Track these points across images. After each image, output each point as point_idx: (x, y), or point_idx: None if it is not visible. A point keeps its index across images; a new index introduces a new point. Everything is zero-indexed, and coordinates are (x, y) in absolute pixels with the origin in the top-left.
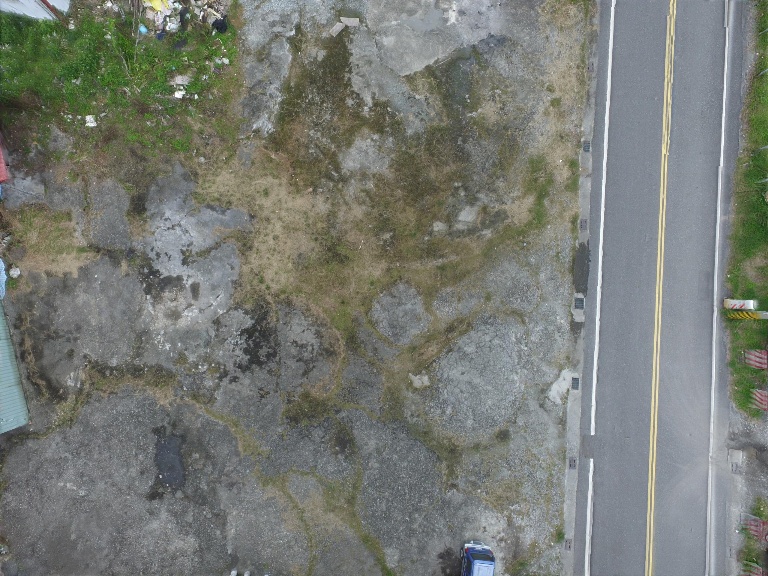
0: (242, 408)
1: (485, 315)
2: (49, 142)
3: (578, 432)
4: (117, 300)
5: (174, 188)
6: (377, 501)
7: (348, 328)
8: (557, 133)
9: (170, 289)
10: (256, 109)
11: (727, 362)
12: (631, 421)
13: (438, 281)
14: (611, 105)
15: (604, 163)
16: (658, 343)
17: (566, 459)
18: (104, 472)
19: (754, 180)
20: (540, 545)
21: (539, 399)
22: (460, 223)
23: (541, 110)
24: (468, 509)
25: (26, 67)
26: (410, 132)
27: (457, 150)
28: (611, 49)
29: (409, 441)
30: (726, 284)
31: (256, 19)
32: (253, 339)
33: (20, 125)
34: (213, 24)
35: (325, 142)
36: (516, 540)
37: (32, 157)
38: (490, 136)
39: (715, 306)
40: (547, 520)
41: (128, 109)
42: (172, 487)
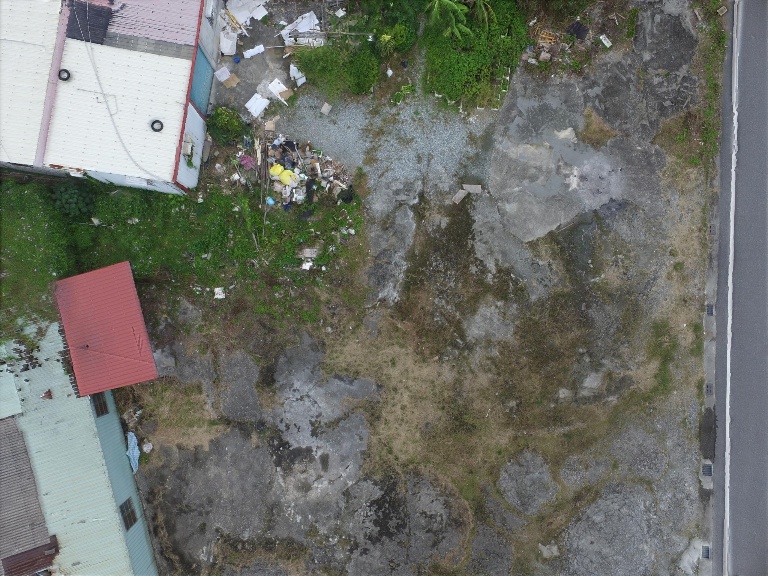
0: None
1: (613, 483)
2: (179, 315)
3: None
4: (248, 473)
5: (302, 359)
6: None
7: (477, 498)
8: (681, 297)
9: (300, 461)
10: (381, 278)
11: None
12: None
13: (565, 449)
14: (734, 268)
15: (728, 327)
16: None
17: None
18: None
19: None
20: None
21: (669, 568)
22: (586, 390)
23: (664, 275)
24: None
25: (157, 243)
26: (534, 298)
27: (581, 316)
28: (733, 212)
29: None
30: None
31: (380, 188)
32: (383, 510)
33: (150, 299)
34: (339, 195)
35: (450, 310)
36: None
37: (162, 330)
38: (614, 301)
39: None
40: None
41: (257, 282)
42: None
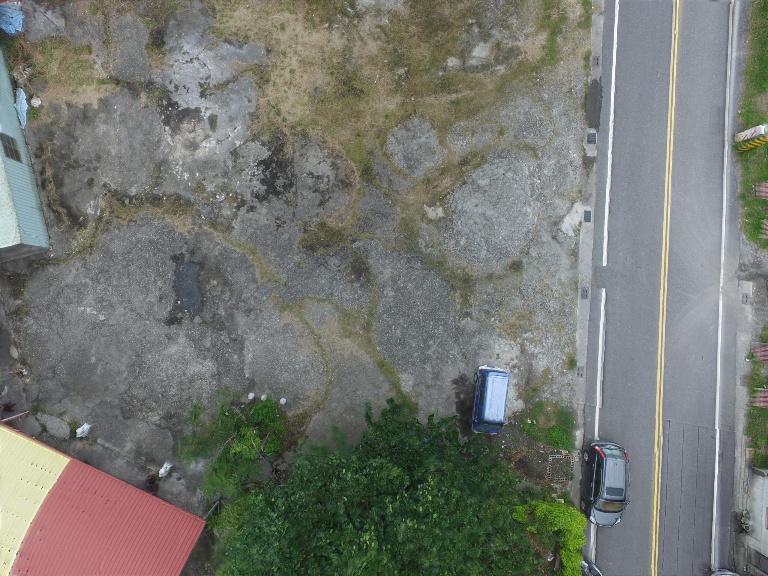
0: (259, 237)
1: (499, 149)
2: None
3: (590, 263)
4: (136, 131)
5: (192, 22)
6: (392, 328)
7: (363, 160)
8: None
9: (188, 121)
10: None
11: (738, 195)
12: (643, 252)
13: (452, 115)
14: None
15: (616, 1)
16: (670, 175)
17: (578, 289)
18: (124, 297)
19: (765, 16)
20: (553, 372)
21: (552, 231)
22: (474, 59)
23: None
24: (482, 337)
25: None
26: None
27: None
28: None
29: (423, 270)
30: (737, 119)
31: None
32: (270, 170)
33: None
34: None
35: None
36: (529, 367)
37: None
38: None
39: (726, 141)
40: (560, 348)
41: None
42: (190, 313)
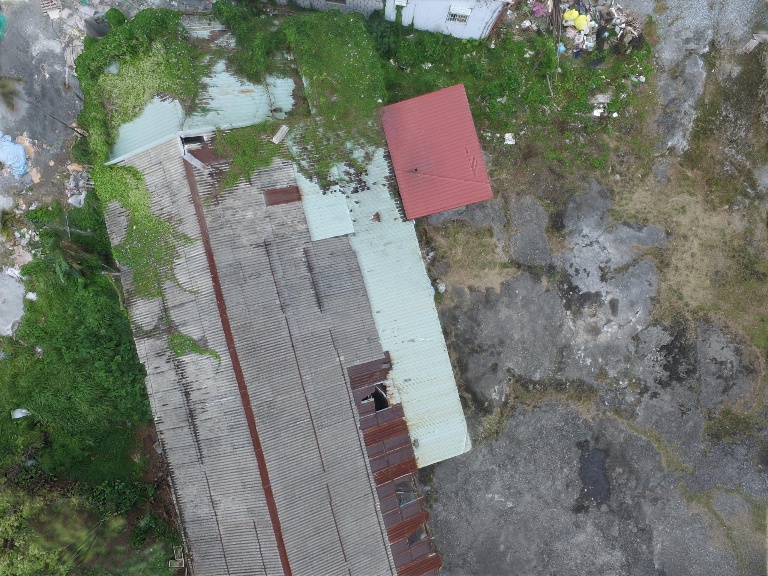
0: (664, 424)
1: None
2: None
3: None
4: (538, 315)
5: (591, 205)
6: None
7: (767, 346)
8: None
9: (589, 305)
10: (671, 126)
11: None
12: None
13: None
14: None
15: None
16: None
17: None
18: (531, 484)
19: None
20: None
21: None
22: None
23: None
24: None
25: None
26: None
27: None
28: None
29: None
30: None
31: (669, 37)
32: (673, 356)
33: None
34: (630, 42)
35: (740, 159)
36: None
37: None
38: None
39: None
40: None
41: (548, 127)
42: (597, 501)
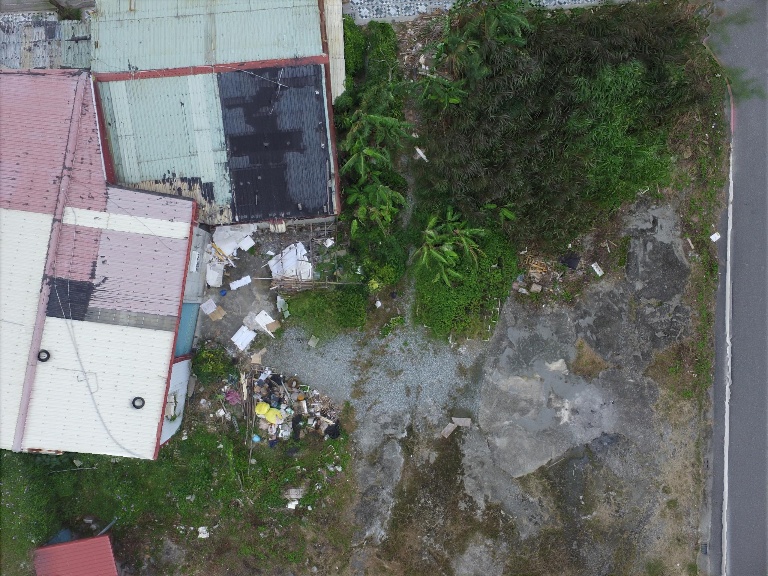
0: None
1: None
2: (162, 555)
3: None
4: None
5: None
6: None
7: None
8: (674, 536)
9: None
10: (369, 515)
11: None
12: None
13: None
14: (728, 506)
15: (722, 567)
16: None
17: None
18: None
19: None
20: None
21: None
22: None
23: (657, 512)
24: None
25: (140, 484)
26: (524, 537)
27: (572, 555)
28: (727, 448)
29: None
30: None
31: (368, 421)
32: None
33: (133, 539)
34: (325, 431)
35: (438, 548)
36: None
37: (144, 570)
38: (606, 540)
39: None
40: None
41: (241, 522)
42: None
